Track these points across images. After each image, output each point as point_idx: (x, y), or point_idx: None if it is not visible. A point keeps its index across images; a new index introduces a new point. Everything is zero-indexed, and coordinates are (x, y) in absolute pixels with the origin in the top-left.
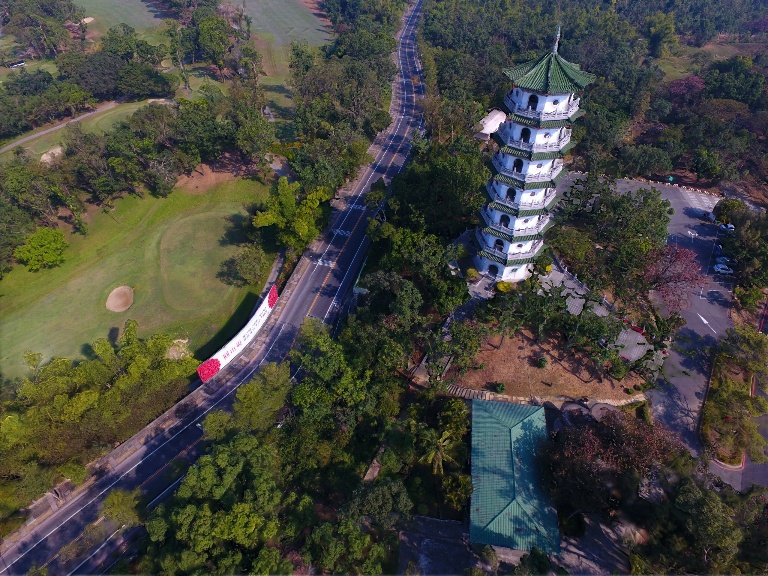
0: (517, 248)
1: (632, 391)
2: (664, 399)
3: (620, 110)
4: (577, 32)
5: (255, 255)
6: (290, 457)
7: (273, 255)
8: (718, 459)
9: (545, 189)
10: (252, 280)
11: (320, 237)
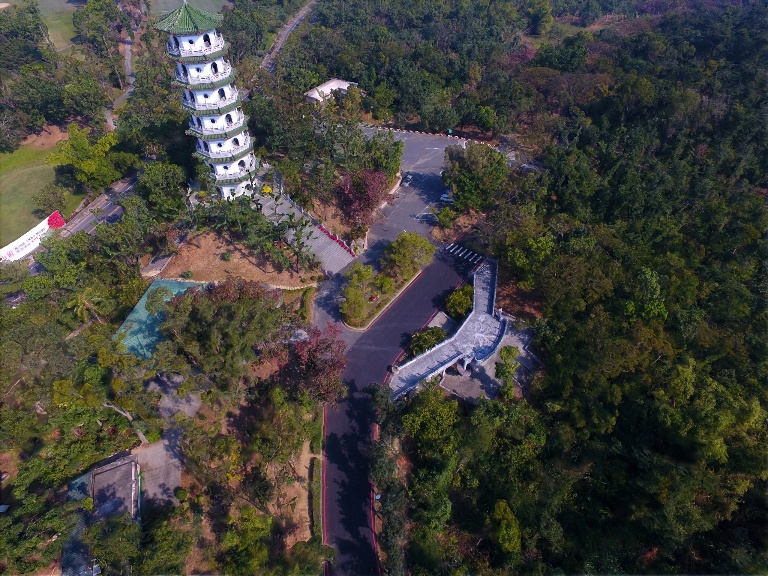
0: (224, 170)
1: (304, 280)
2: (333, 287)
3: (455, 79)
4: (461, 13)
5: (52, 190)
6: (4, 323)
7: (84, 195)
8: (347, 324)
9: (229, 118)
10: (49, 211)
11: (126, 180)
